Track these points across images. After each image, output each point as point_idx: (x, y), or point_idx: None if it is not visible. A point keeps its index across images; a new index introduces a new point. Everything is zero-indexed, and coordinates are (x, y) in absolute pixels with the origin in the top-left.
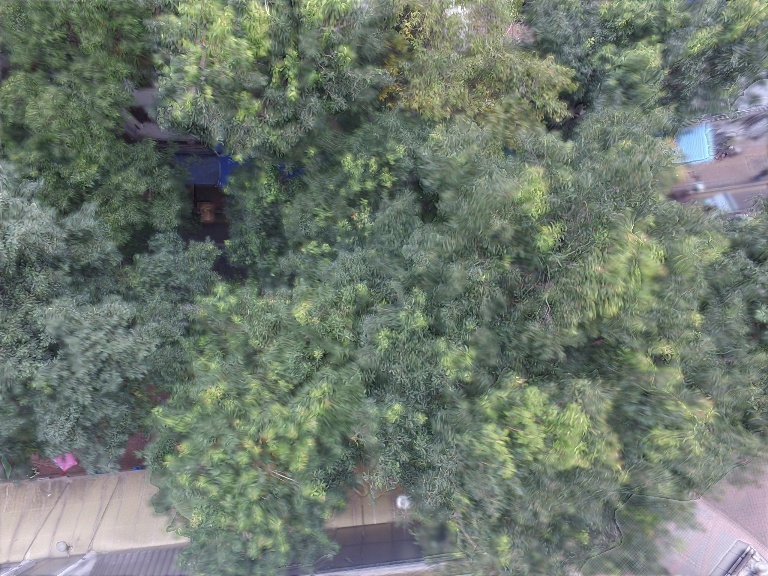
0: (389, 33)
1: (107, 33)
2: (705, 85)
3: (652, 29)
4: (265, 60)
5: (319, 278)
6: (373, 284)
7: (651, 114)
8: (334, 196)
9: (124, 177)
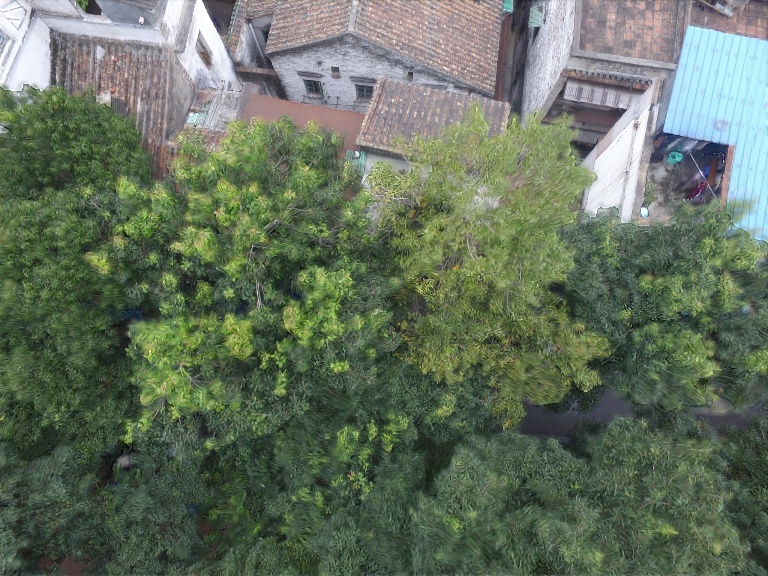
0: (399, 276)
1: (85, 292)
2: (760, 378)
3: (700, 314)
4: (253, 352)
5: (310, 526)
6: (367, 569)
7: (702, 498)
8: (330, 438)
9: (103, 406)
